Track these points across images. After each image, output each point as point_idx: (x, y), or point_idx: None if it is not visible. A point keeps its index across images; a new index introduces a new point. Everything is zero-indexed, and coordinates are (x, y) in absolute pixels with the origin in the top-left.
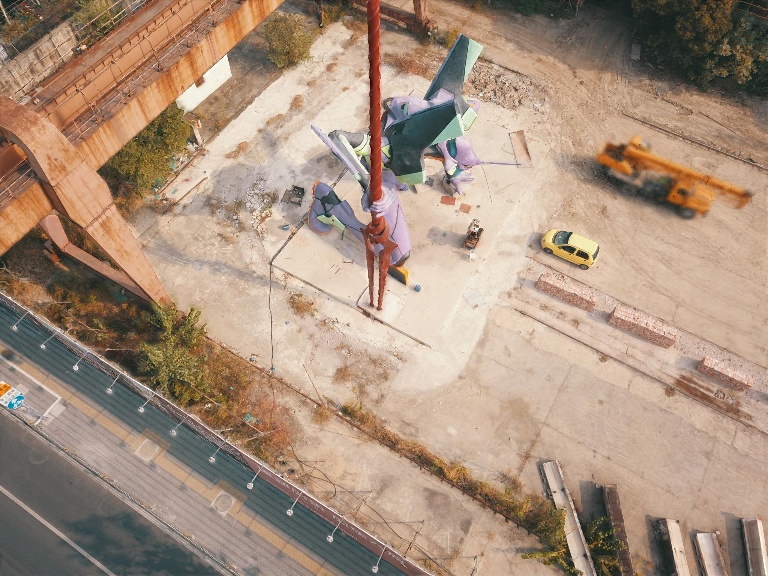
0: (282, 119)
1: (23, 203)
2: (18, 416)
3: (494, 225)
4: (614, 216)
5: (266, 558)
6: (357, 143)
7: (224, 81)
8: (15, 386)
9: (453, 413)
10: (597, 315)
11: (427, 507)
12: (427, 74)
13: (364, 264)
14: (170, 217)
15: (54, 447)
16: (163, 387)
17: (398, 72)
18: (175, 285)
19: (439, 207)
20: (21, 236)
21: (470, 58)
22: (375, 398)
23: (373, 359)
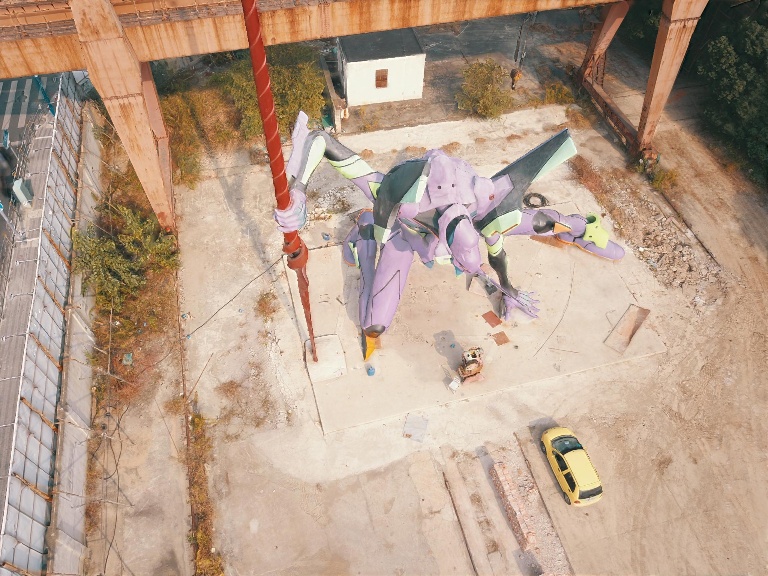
0: (422, 153)
1: (59, 44)
2: (8, 225)
3: (513, 376)
4: (671, 479)
5: (6, 473)
6: (338, 157)
7: (410, 98)
8: (38, 208)
9: (274, 511)
10: (527, 562)
11: (154, 569)
12: (599, 195)
13: (351, 313)
14: (257, 169)
15: (8, 265)
16: (78, 271)
17: (572, 177)
18: (203, 220)
19: (476, 318)
20: (49, 72)
21: (555, 158)
22: (230, 432)
23: (267, 399)
